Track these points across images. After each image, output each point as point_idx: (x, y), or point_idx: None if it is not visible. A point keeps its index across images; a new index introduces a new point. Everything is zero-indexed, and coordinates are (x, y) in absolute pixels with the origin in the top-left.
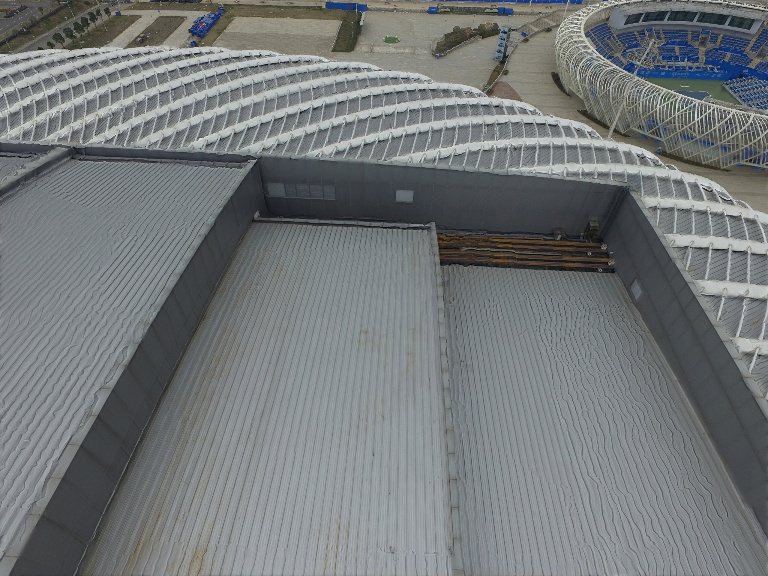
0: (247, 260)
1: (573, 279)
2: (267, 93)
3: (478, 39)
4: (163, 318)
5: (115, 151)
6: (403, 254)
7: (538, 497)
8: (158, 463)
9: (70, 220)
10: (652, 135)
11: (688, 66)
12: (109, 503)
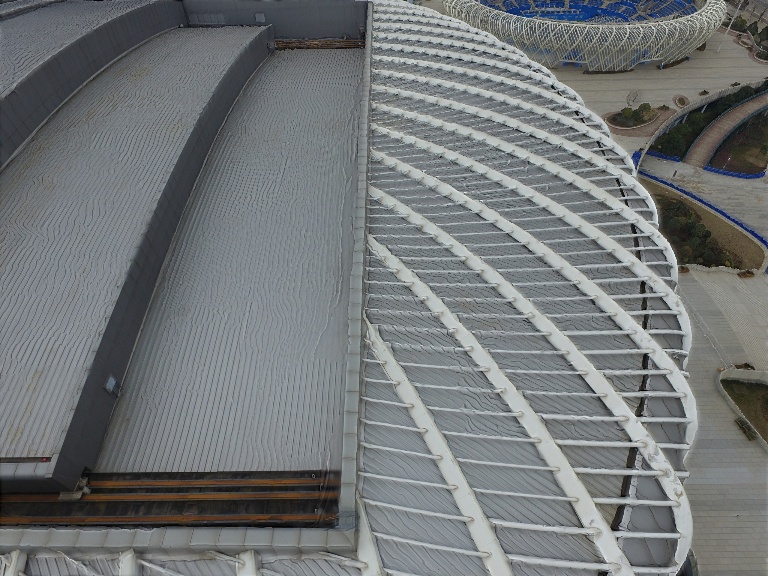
0: None
1: (345, 50)
2: None
3: None
4: (131, 15)
5: None
6: None
7: None
8: (131, 59)
9: (90, 4)
10: None
11: (556, 11)
12: (114, 63)
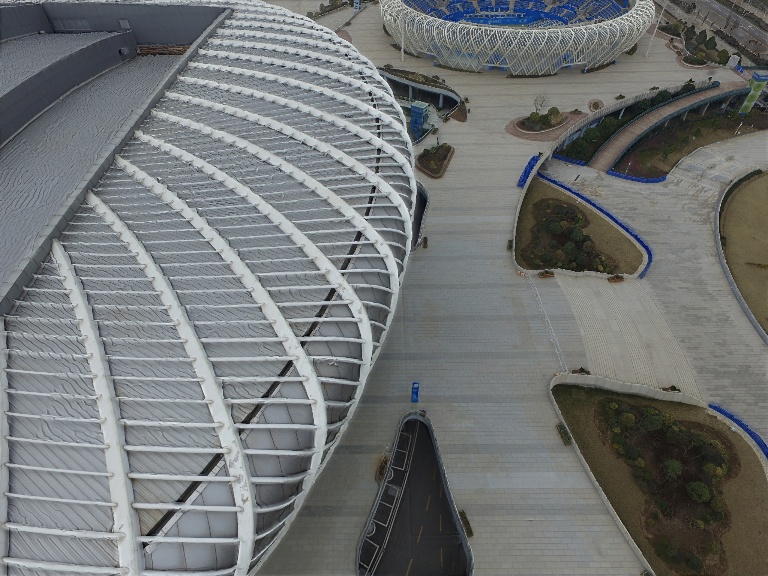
0: (24, 39)
1: None
2: None
3: (347, 7)
4: None
5: None
6: None
7: None
8: None
9: None
10: (429, 52)
11: (501, 14)
12: None
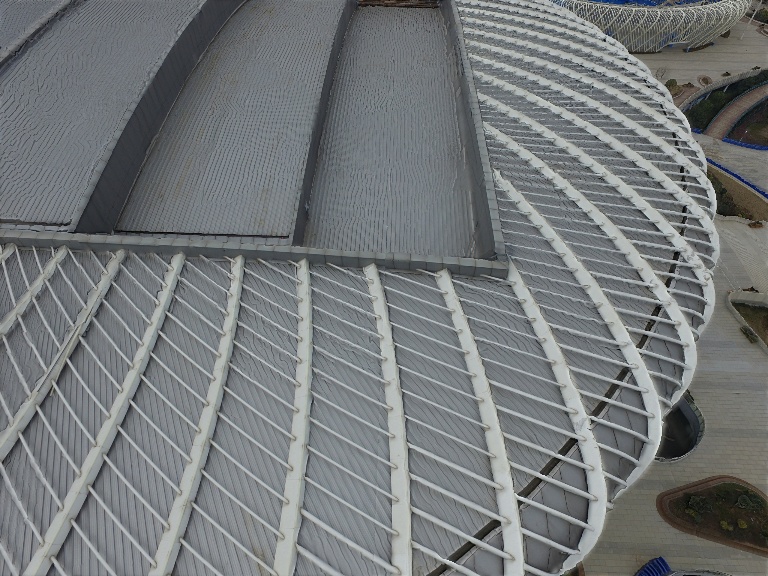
0: None
1: None
2: None
3: None
4: None
5: None
6: None
7: None
8: (257, 1)
9: None
10: None
11: None
12: (245, 3)
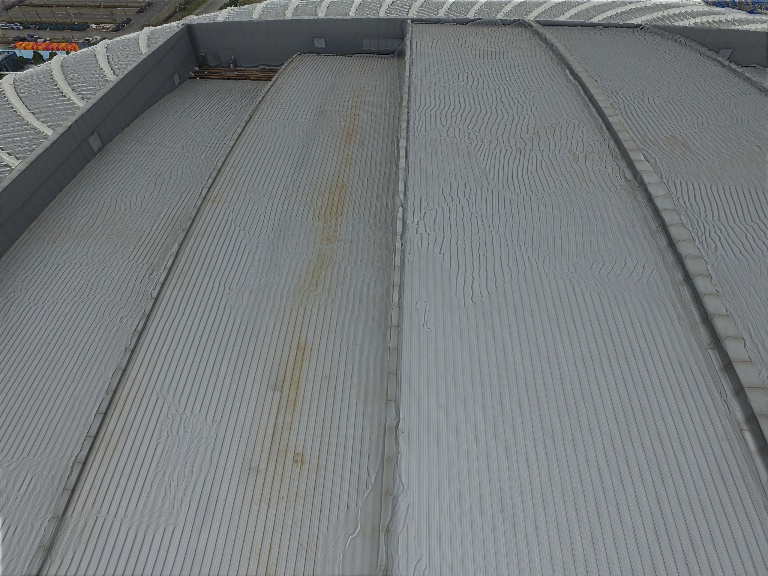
0: None
1: None
2: (594, 1)
3: None
4: None
5: (555, 22)
6: (757, 73)
7: None
8: None
9: None
10: None
11: None
12: None
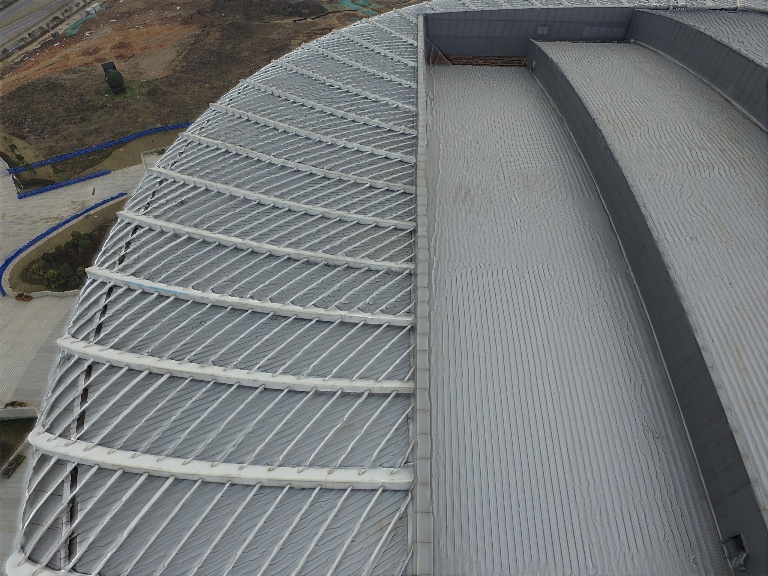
0: None
1: None
2: None
3: None
4: None
5: None
6: None
7: (575, 310)
8: None
9: None
10: None
11: None
12: None
